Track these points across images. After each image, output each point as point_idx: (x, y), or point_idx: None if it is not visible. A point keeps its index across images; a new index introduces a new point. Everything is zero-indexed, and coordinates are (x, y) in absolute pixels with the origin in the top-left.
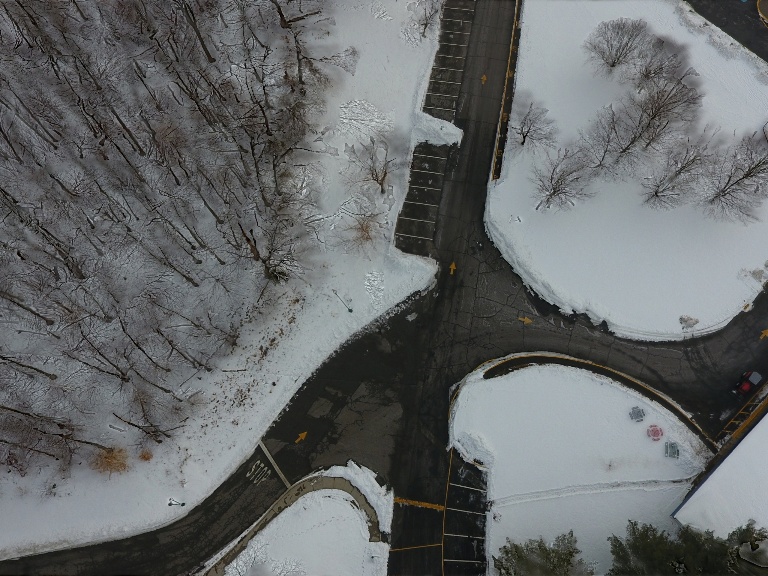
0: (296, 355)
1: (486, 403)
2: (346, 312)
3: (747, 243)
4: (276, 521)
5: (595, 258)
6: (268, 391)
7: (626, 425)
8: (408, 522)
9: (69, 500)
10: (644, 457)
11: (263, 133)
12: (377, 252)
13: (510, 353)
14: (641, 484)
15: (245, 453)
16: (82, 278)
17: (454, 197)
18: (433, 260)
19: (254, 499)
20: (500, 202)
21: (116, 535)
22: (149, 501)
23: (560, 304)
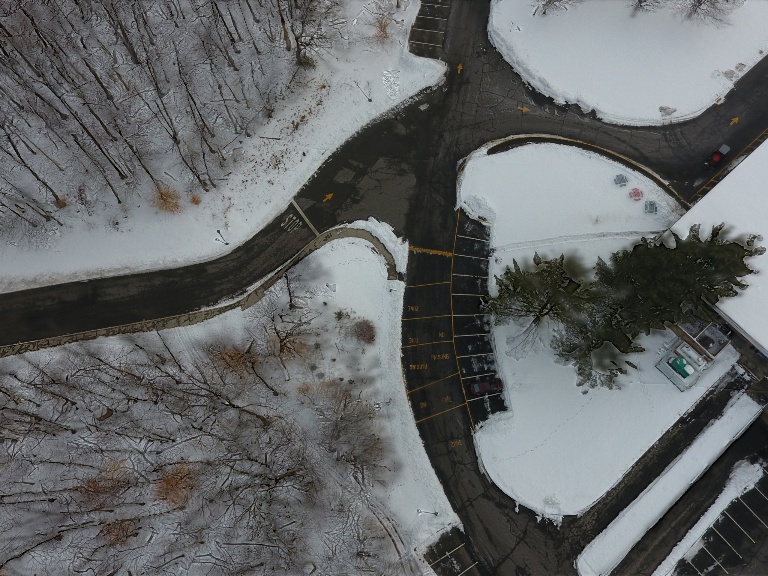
0: (323, 133)
1: (489, 173)
2: (366, 101)
3: (720, 50)
4: (307, 258)
5: (586, 60)
6: (299, 160)
7: (611, 189)
8: (421, 265)
9: (130, 235)
10: (627, 214)
11: None
12: (393, 55)
13: (510, 135)
14: (624, 234)
15: (280, 208)
16: (137, 63)
17: (461, 12)
18: (442, 62)
19: (288, 243)
20: (502, 16)
21: (170, 264)
22: (198, 239)
23: (554, 96)
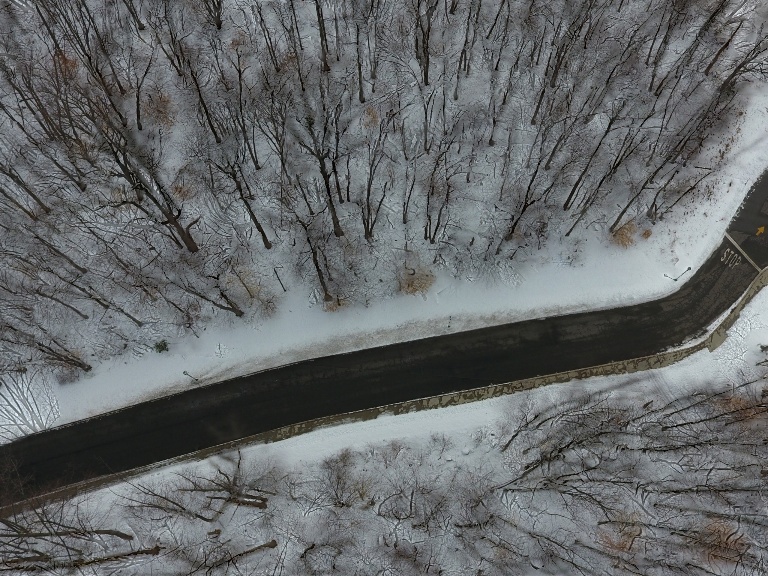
0: (743, 162)
1: None
2: None
3: None
4: (759, 296)
5: None
6: (726, 190)
7: None
8: None
9: (582, 270)
10: None
11: None
12: None
13: None
14: None
15: (716, 241)
16: (553, 86)
17: None
18: None
19: (733, 279)
20: None
21: (626, 302)
22: (649, 275)
23: None
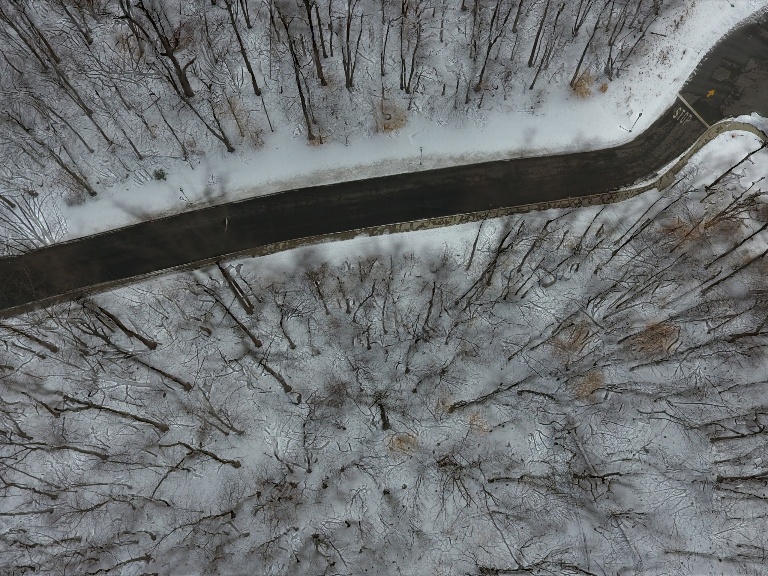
0: (697, 33)
1: None
2: (729, 6)
3: None
4: (707, 147)
5: None
6: (680, 57)
7: None
8: None
9: (544, 119)
10: None
11: None
12: None
13: None
14: None
15: (669, 101)
16: None
17: None
18: None
19: (683, 133)
20: None
21: (584, 148)
22: (605, 125)
23: None
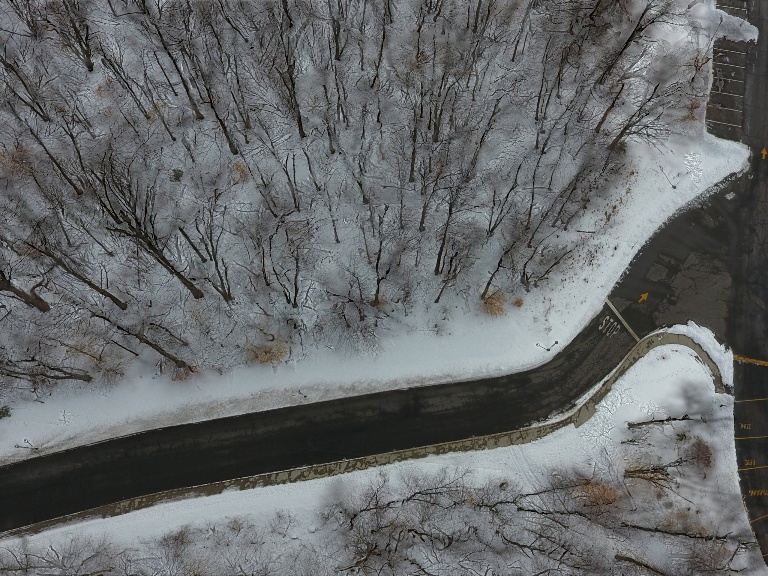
0: (631, 224)
1: None
2: (670, 188)
3: None
4: (634, 369)
5: None
6: (610, 254)
7: None
8: (748, 377)
9: (450, 339)
10: None
11: (586, 17)
12: None
13: None
14: None
15: (595, 309)
16: (436, 141)
17: (758, 89)
18: (745, 145)
19: (609, 349)
20: None
21: (493, 373)
22: (520, 344)
23: None
